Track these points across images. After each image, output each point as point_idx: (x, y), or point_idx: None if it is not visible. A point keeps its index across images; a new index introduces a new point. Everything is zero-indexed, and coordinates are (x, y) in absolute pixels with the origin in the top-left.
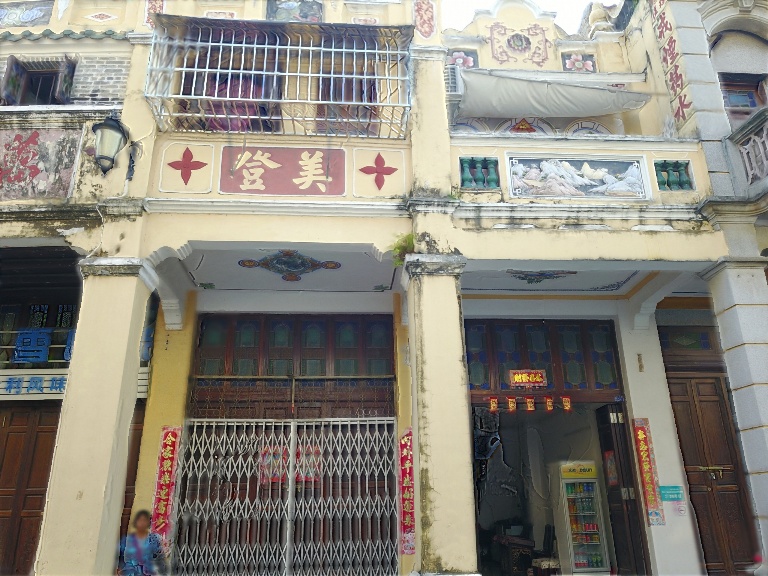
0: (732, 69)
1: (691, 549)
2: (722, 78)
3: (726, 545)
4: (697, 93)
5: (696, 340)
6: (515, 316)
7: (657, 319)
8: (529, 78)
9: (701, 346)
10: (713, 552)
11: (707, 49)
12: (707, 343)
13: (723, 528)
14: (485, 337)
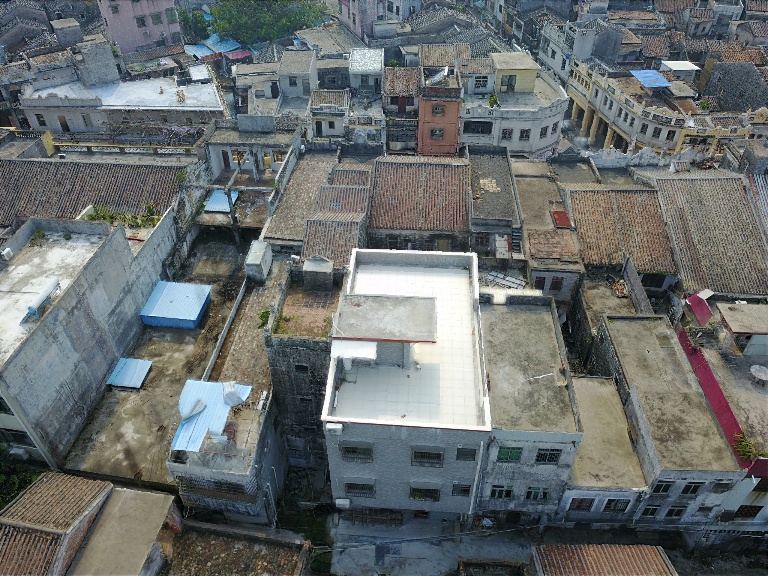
0: None
1: None
2: None
3: None
4: None
5: None
6: None
7: None
8: None
9: None
10: None
11: None
12: None
13: None
14: None
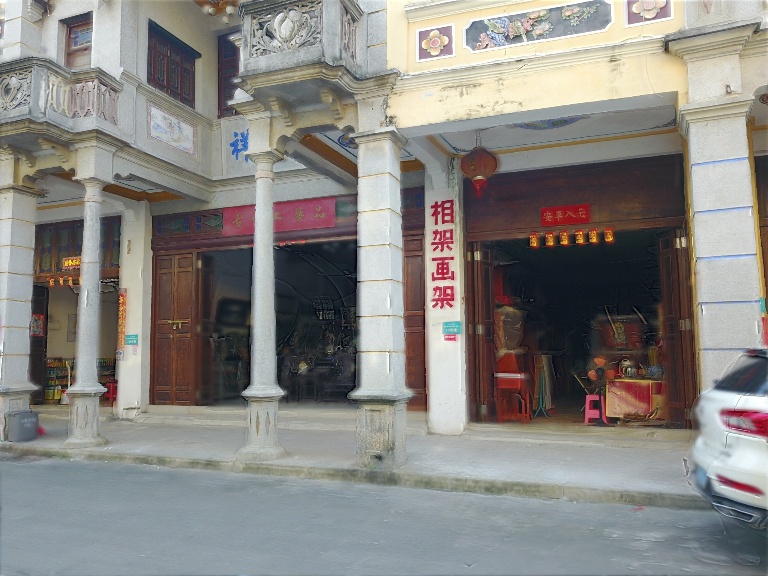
0: (68, 14)
1: (135, 376)
2: (69, 22)
3: (174, 375)
4: (6, 55)
5: (181, 224)
6: (66, 219)
7: (153, 211)
8: (2, 44)
9: (183, 229)
10: (166, 379)
11: (21, 12)
12: (187, 226)
13: (174, 363)
14: (52, 236)
